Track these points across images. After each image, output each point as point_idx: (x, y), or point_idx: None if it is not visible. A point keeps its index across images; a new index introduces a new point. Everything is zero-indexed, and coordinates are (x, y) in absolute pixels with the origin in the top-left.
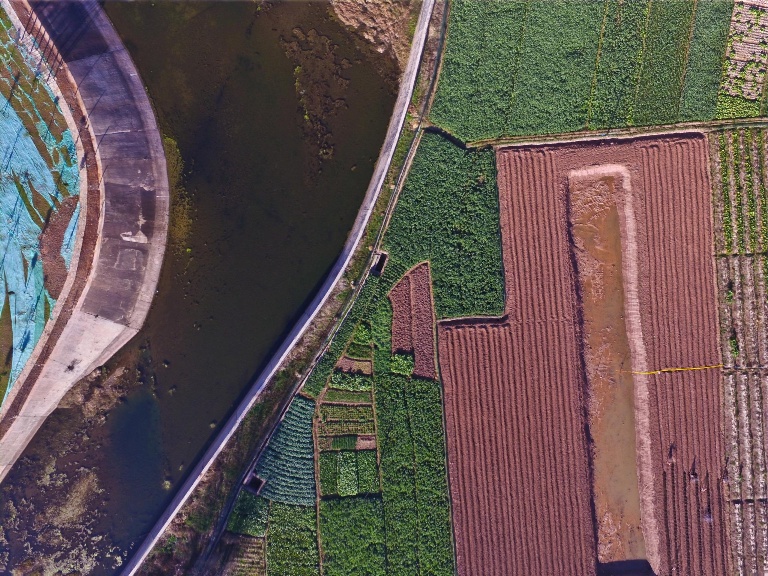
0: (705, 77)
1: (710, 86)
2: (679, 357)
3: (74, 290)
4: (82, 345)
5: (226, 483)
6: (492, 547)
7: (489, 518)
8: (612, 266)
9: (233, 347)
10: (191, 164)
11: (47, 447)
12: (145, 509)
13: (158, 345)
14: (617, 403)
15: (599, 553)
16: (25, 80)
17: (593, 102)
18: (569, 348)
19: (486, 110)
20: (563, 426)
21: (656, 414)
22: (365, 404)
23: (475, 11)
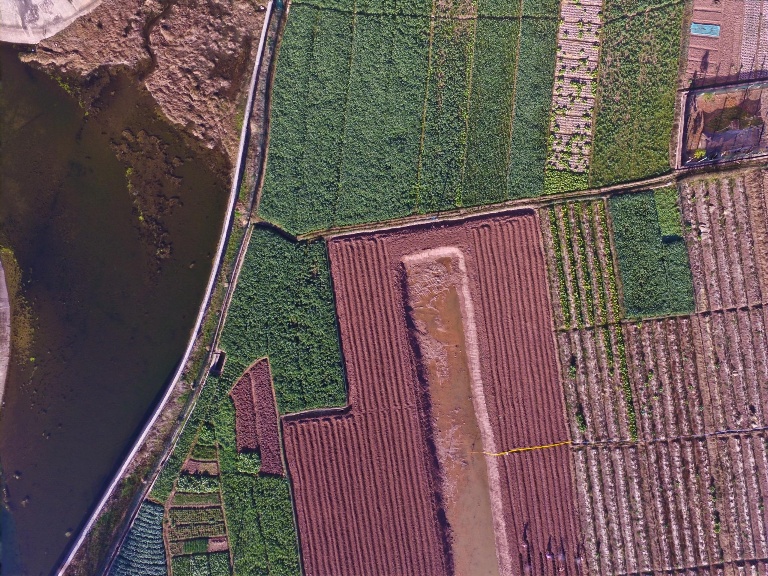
0: (530, 154)
1: (535, 162)
2: (526, 436)
3: None
4: None
5: None
6: None
7: None
8: (455, 347)
9: (84, 453)
10: (29, 273)
11: None
12: None
13: (8, 457)
14: (471, 485)
15: None
16: None
17: (420, 186)
18: (414, 435)
19: (313, 202)
20: (414, 514)
21: (507, 496)
22: (214, 505)
23: (295, 105)
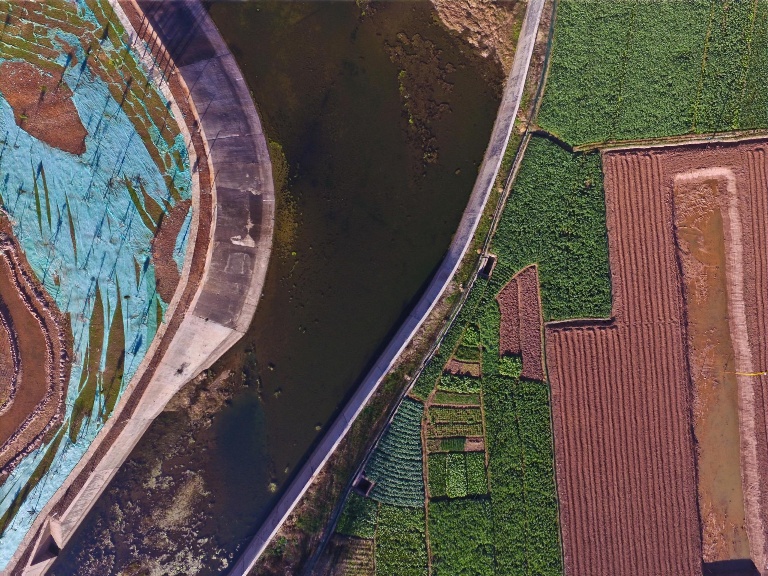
0: None
1: None
2: None
3: (186, 294)
4: (192, 348)
5: (336, 485)
6: (600, 547)
7: (597, 519)
8: (716, 268)
9: (338, 350)
10: (296, 168)
11: (153, 450)
12: (250, 511)
13: (263, 348)
14: (721, 404)
15: (703, 553)
16: (137, 85)
17: (699, 106)
18: (676, 350)
19: (594, 114)
20: (670, 427)
21: (762, 415)
22: (473, 406)
23: (583, 16)
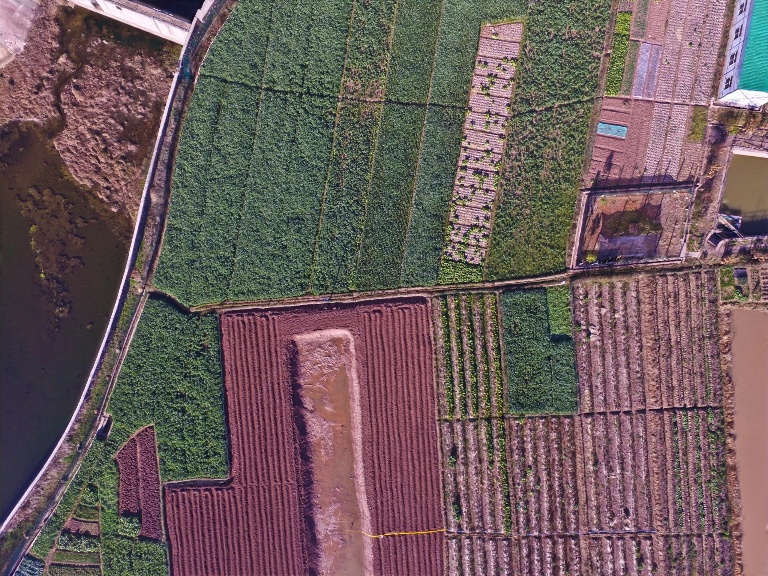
0: (426, 243)
1: (431, 252)
2: (402, 521)
3: None
4: None
5: None
6: None
7: None
8: (341, 427)
9: None
10: None
11: None
12: None
13: None
14: (347, 562)
15: None
16: None
17: (315, 267)
18: (292, 512)
19: (208, 276)
20: None
21: None
22: (93, 564)
23: (196, 177)
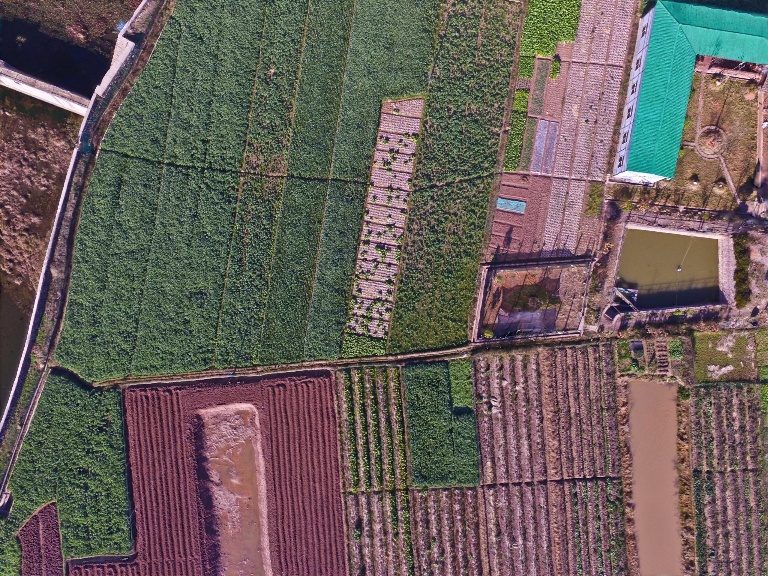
0: (329, 317)
1: (333, 326)
2: None
3: None
4: None
5: None
6: None
7: None
8: (248, 499)
9: None
10: None
11: None
12: None
13: None
14: None
15: None
16: None
17: (218, 342)
18: None
19: (110, 351)
20: None
21: None
22: None
23: (97, 253)
